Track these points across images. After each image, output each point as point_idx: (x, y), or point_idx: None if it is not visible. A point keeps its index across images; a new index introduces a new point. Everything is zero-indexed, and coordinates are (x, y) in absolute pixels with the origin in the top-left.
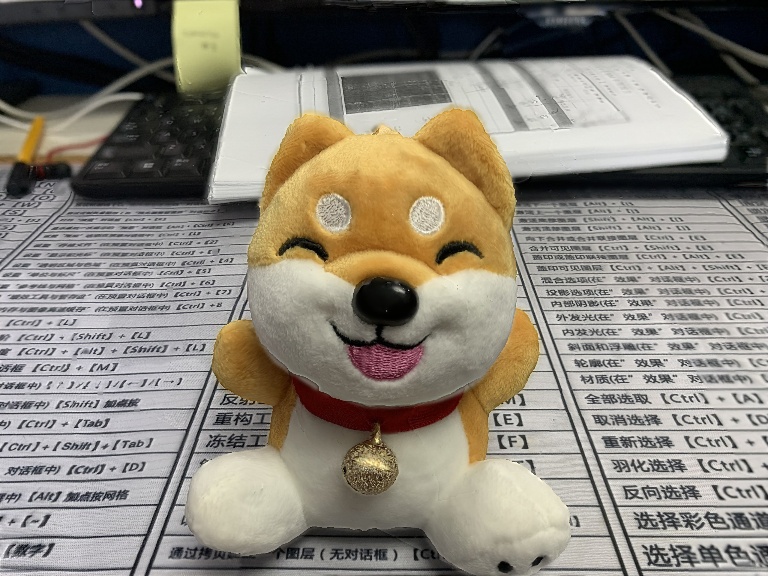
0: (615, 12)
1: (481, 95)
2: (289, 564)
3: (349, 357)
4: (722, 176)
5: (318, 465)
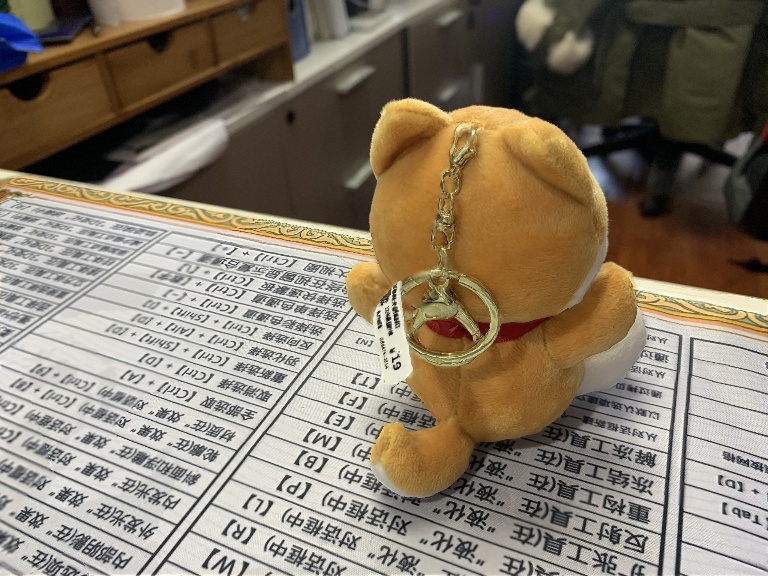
0: None
1: None
2: None
3: None
4: None
5: None
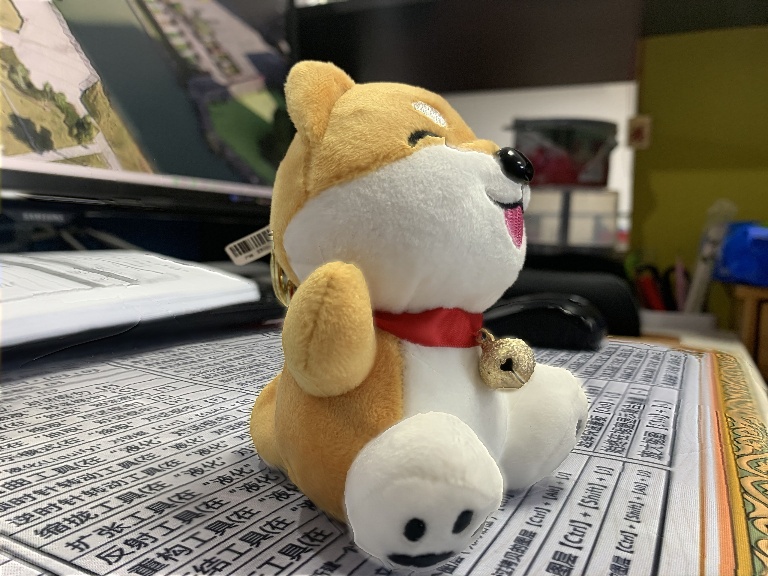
0: (83, 215)
1: (10, 269)
2: (460, 574)
3: (505, 223)
4: (262, 312)
5: (459, 400)
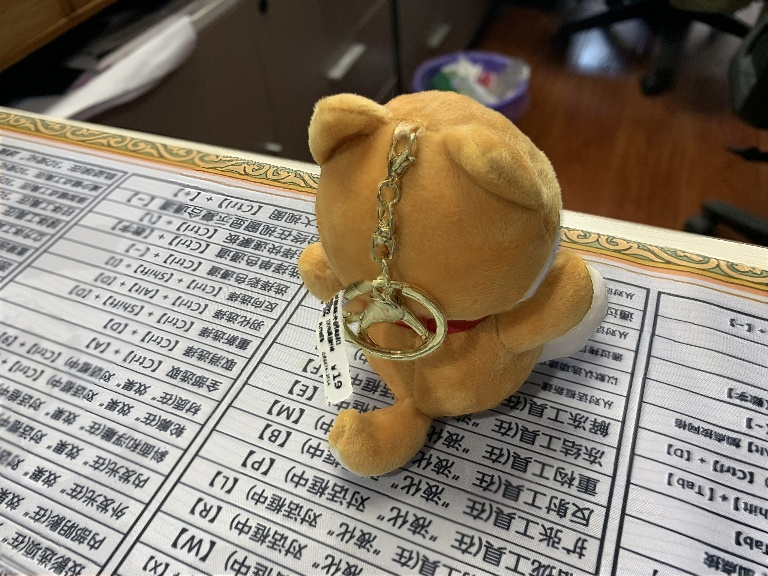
0: None
1: None
2: None
3: None
4: None
5: None
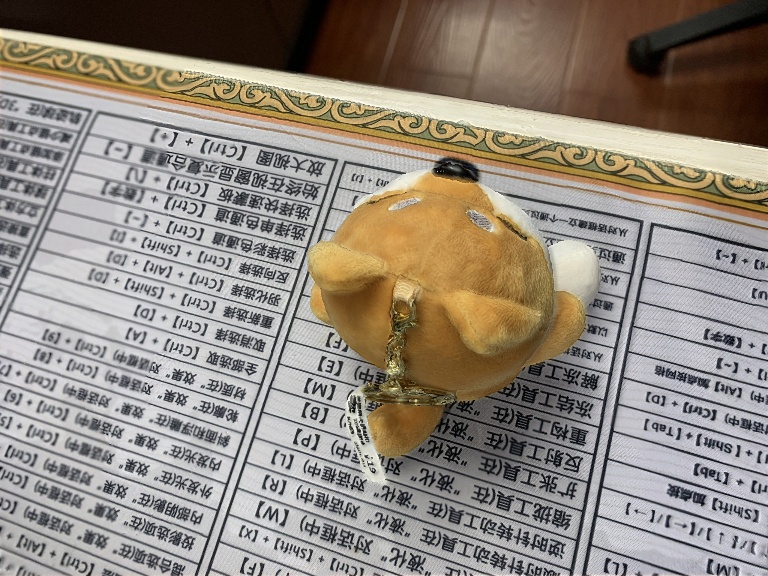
0: None
1: None
2: None
3: None
4: None
5: None
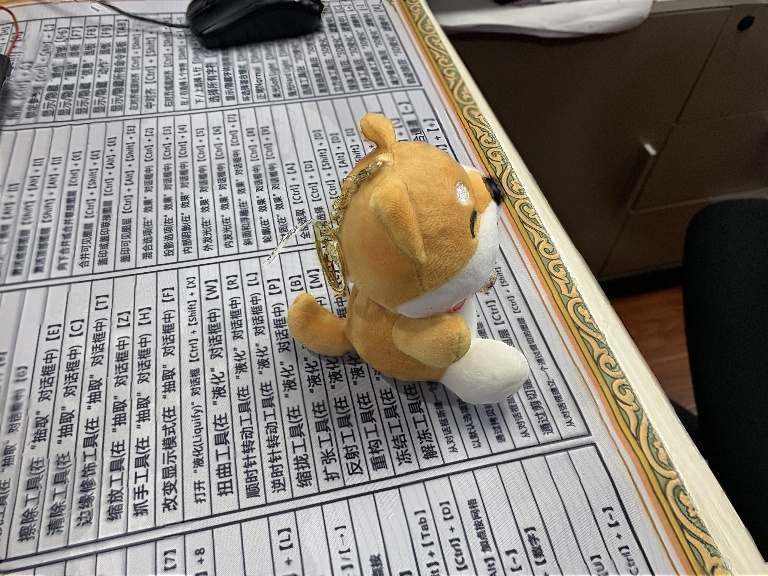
0: None
1: None
2: None
3: None
4: None
5: None
